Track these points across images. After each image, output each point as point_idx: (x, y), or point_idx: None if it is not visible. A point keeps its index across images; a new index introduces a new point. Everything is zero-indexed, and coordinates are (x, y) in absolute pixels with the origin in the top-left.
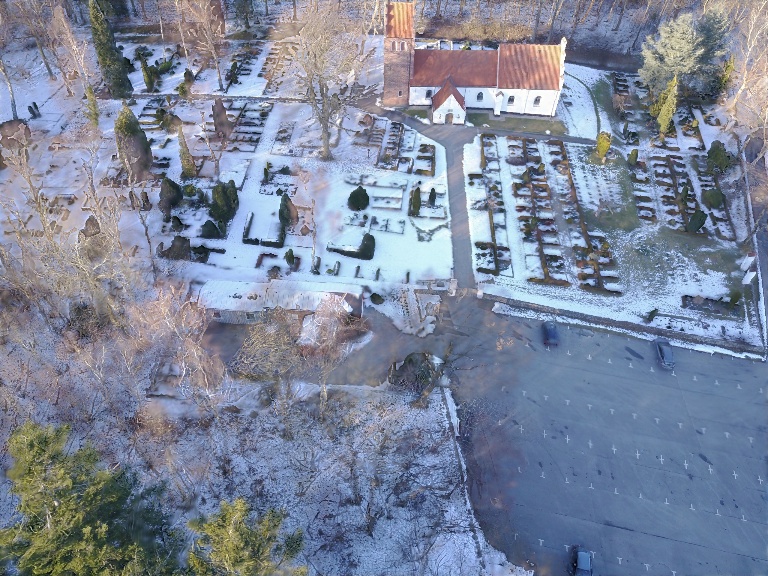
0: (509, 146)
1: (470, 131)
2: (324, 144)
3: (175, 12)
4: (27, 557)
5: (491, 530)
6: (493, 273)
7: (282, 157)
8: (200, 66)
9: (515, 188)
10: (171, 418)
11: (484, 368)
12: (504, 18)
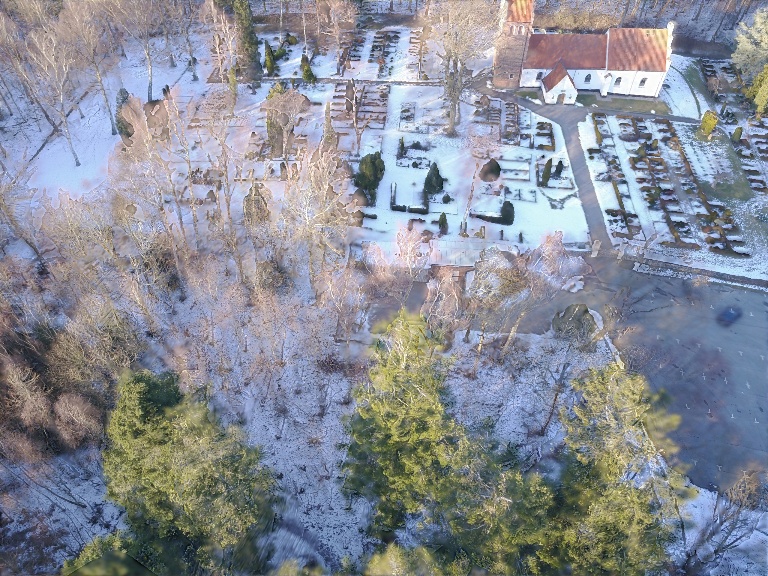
0: (620, 124)
1: (581, 110)
2: (450, 121)
3: (271, 5)
4: (397, 424)
5: (672, 457)
6: (627, 237)
7: (410, 134)
8: (311, 53)
9: (633, 162)
10: (362, 360)
11: (637, 319)
12: (589, 8)
